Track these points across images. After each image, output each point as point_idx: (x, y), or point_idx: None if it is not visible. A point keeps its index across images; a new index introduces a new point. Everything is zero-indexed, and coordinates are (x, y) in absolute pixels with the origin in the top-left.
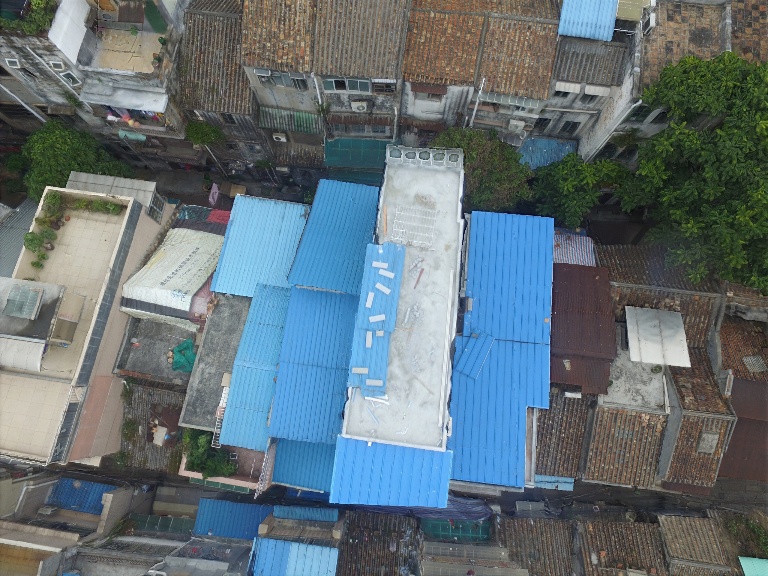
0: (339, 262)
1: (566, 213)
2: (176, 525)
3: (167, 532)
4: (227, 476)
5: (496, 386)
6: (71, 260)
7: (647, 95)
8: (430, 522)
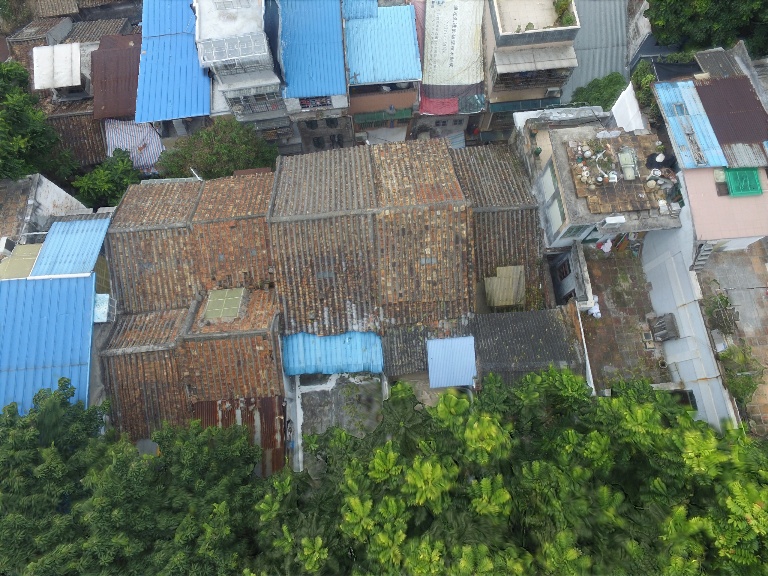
0: (304, 7)
1: (128, 155)
2: None
3: None
4: None
5: (183, 4)
6: (535, 1)
7: (22, 141)
8: None
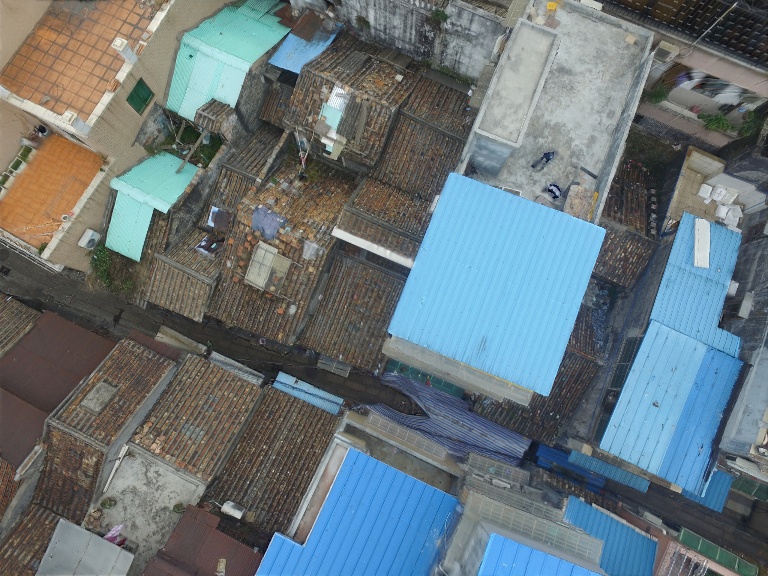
0: None
1: None
2: (750, 487)
3: (763, 484)
4: (720, 575)
5: None
6: None
7: None
8: (453, 391)
